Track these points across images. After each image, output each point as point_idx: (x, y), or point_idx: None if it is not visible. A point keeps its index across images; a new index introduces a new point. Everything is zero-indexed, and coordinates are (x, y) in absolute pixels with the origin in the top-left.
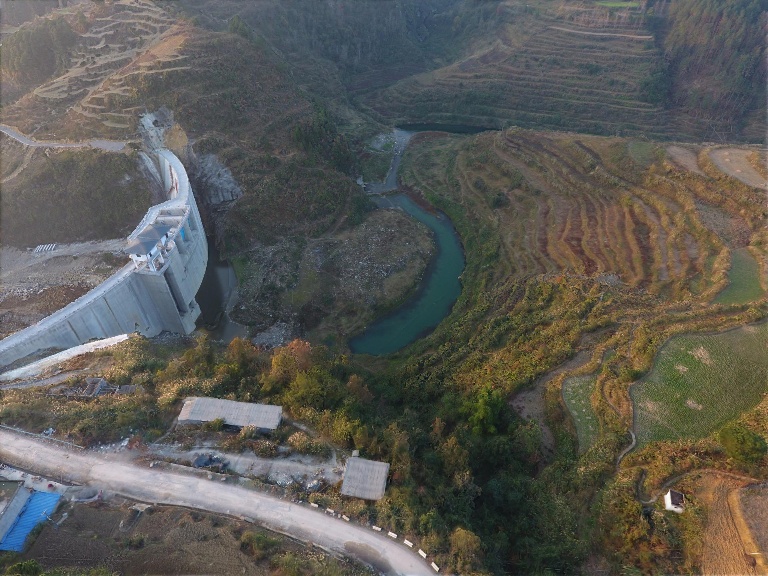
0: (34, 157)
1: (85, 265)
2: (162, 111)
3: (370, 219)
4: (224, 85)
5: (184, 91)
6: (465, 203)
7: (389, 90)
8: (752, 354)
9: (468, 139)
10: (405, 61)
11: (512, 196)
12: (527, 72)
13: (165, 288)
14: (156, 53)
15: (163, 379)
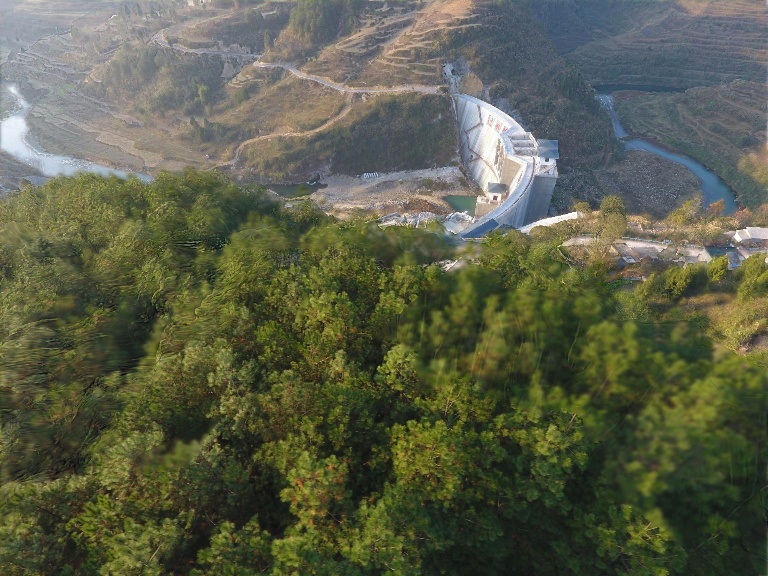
0: (354, 101)
1: (409, 189)
2: (458, 62)
3: (629, 157)
4: (506, 40)
5: (479, 44)
6: (707, 145)
7: (575, 55)
8: None
9: (677, 94)
10: (570, 31)
11: (759, 136)
12: (713, 36)
13: (552, 190)
14: (450, 12)
15: (683, 224)
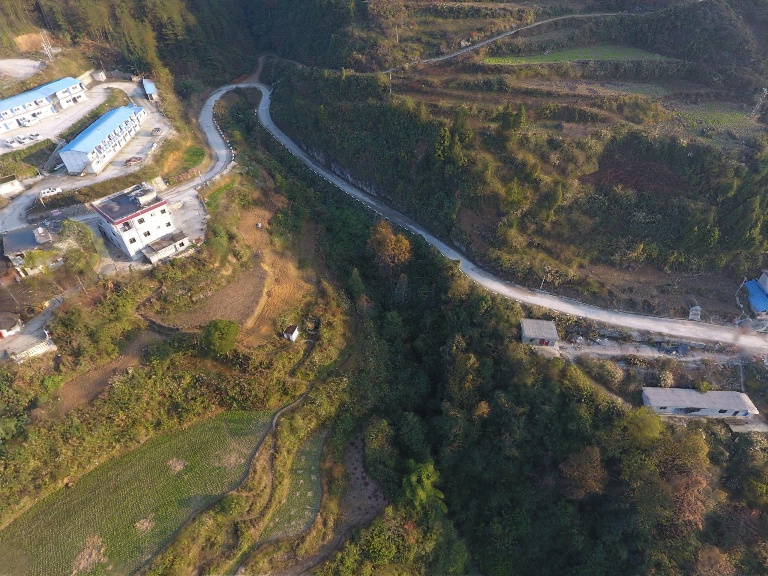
0: None
1: None
2: None
3: None
4: None
5: None
6: None
7: None
8: (5, 563)
9: None
10: None
11: None
12: None
13: None
14: None
15: None
